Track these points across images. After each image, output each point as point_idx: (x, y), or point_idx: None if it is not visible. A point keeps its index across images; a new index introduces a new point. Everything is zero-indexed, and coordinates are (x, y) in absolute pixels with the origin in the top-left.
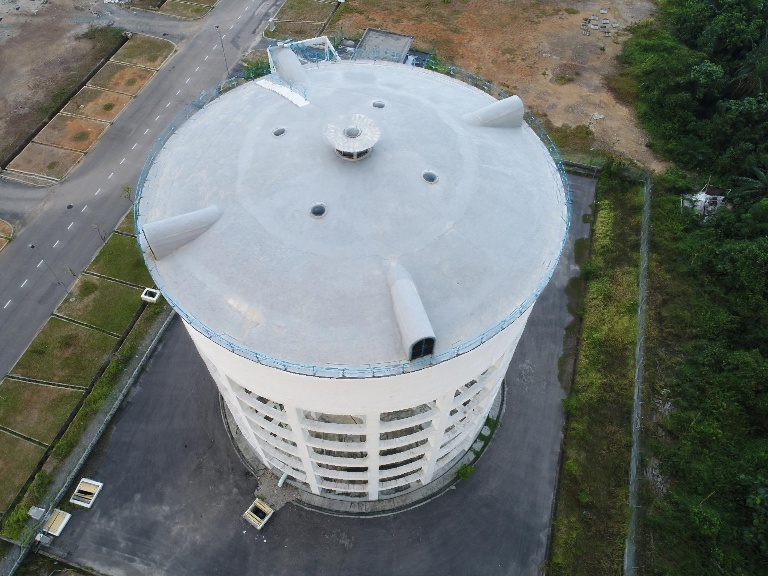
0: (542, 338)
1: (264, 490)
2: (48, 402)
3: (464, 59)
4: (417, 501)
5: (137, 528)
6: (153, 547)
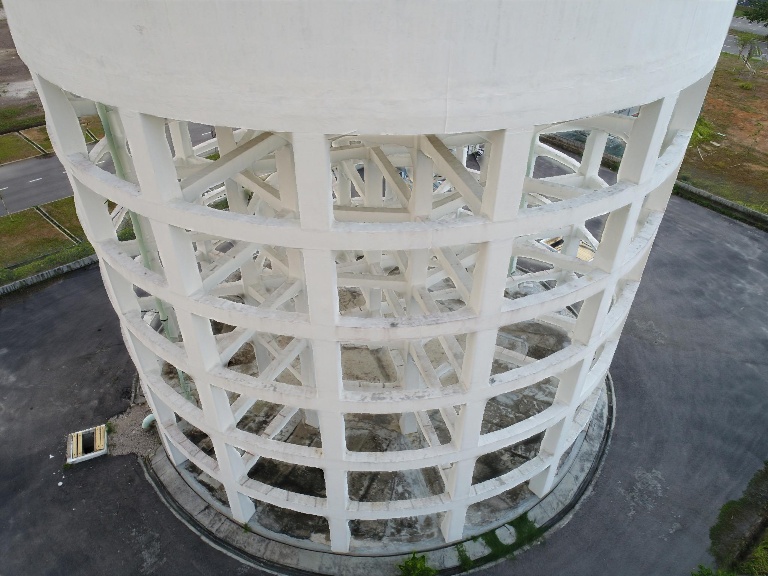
0: (707, 454)
1: (124, 422)
2: (40, 238)
3: (743, 131)
4: (305, 572)
5: None
6: None
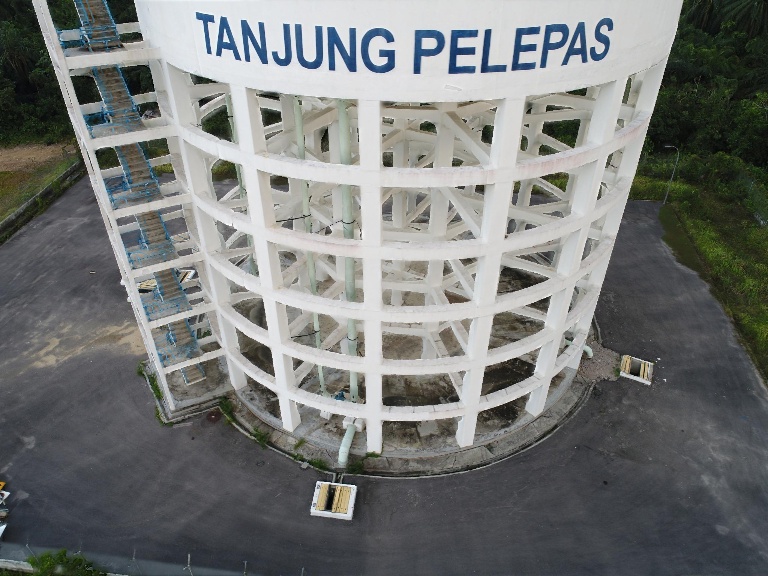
0: None
1: (605, 372)
2: None
3: None
4: None
5: (760, 510)
6: (763, 478)
